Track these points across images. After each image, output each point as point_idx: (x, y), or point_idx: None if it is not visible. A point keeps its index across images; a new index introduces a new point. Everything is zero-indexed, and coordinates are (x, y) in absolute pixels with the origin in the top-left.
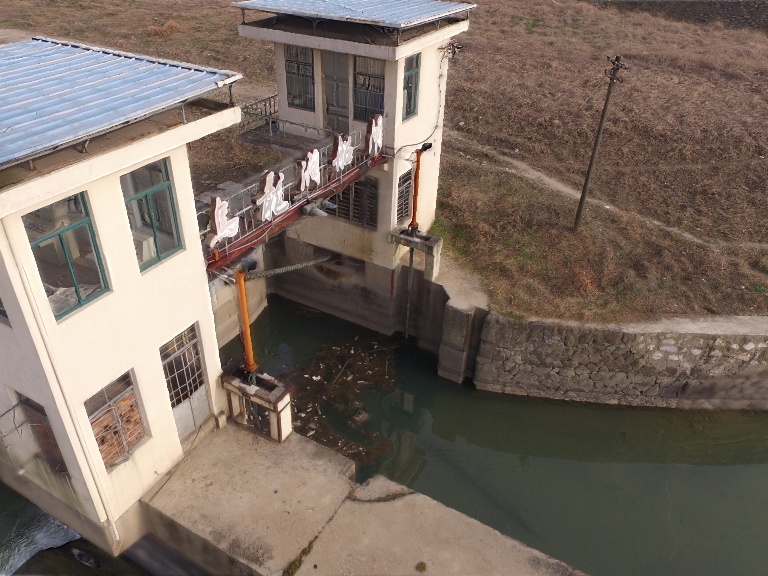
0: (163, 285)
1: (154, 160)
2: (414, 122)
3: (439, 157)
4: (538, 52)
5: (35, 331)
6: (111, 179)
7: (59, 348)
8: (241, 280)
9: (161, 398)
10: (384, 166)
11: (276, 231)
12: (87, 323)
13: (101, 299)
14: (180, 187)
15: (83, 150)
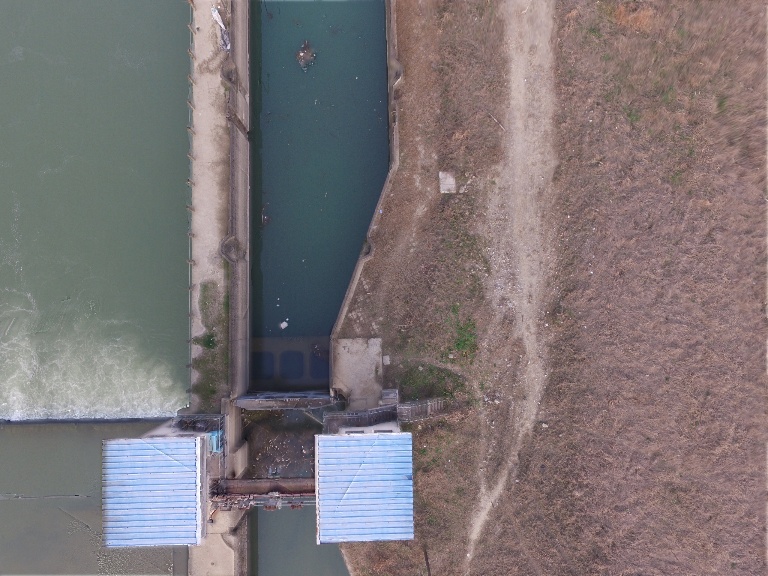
0: None
1: None
2: None
3: None
4: (760, 419)
5: None
6: None
7: None
8: None
9: None
10: None
11: None
12: None
13: None
14: None
15: None
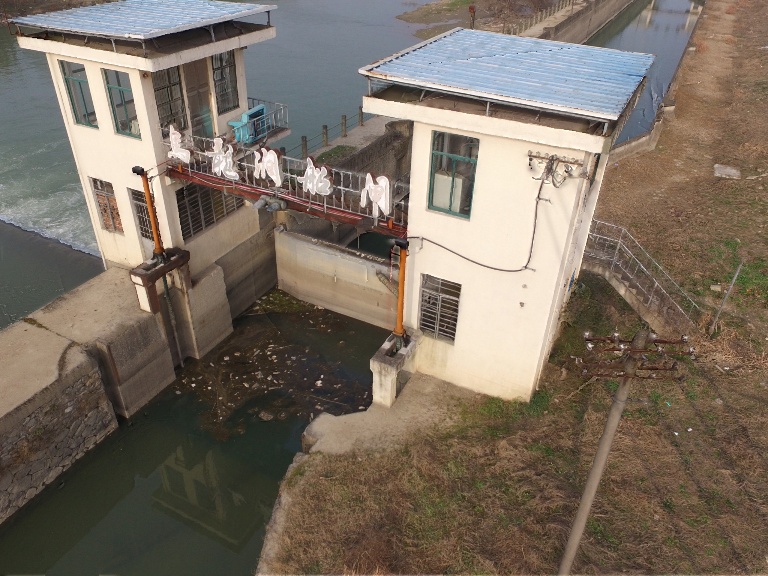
0: (128, 151)
1: None
2: (461, 225)
3: (545, 321)
4: None
5: None
6: None
7: (76, 137)
8: None
9: None
10: None
11: None
12: None
13: (94, 129)
14: None
15: (85, 43)
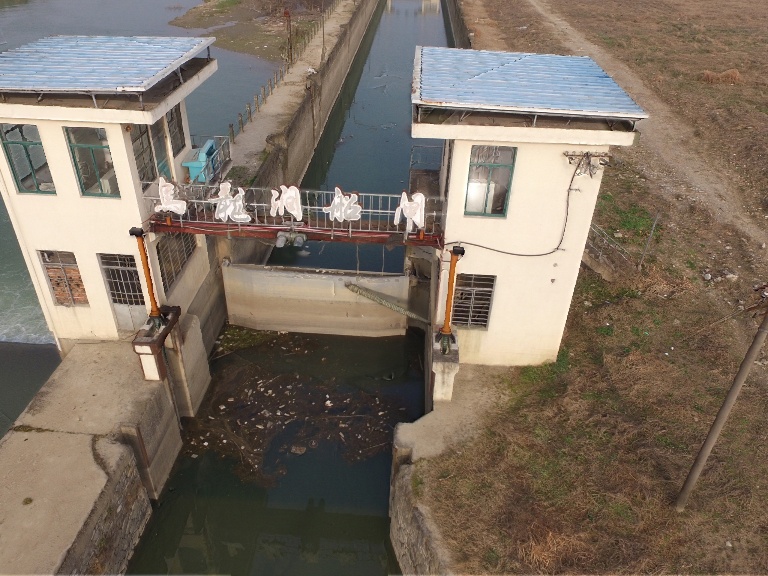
0: (100, 213)
1: (92, 126)
2: (497, 224)
3: (571, 290)
4: None
5: (3, 190)
6: (56, 125)
7: (18, 208)
8: (138, 240)
9: (99, 287)
10: (436, 251)
11: (243, 236)
12: (38, 204)
13: (48, 195)
14: (116, 153)
15: (38, 101)
